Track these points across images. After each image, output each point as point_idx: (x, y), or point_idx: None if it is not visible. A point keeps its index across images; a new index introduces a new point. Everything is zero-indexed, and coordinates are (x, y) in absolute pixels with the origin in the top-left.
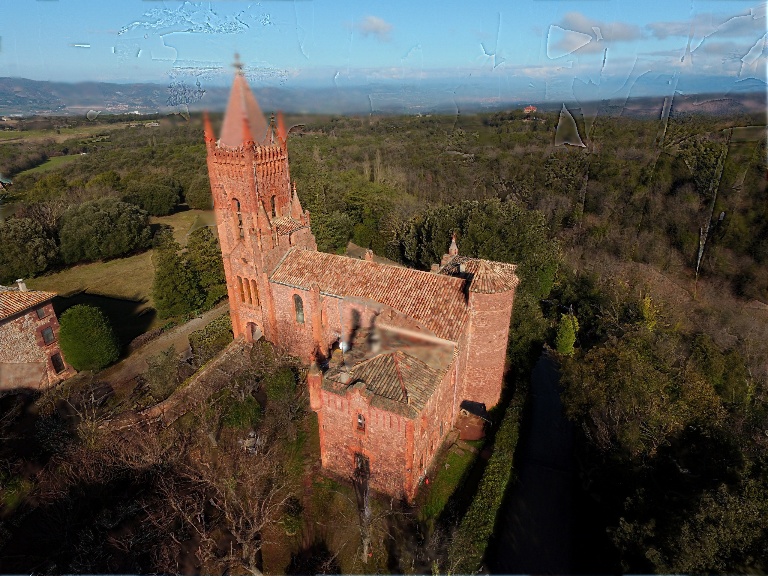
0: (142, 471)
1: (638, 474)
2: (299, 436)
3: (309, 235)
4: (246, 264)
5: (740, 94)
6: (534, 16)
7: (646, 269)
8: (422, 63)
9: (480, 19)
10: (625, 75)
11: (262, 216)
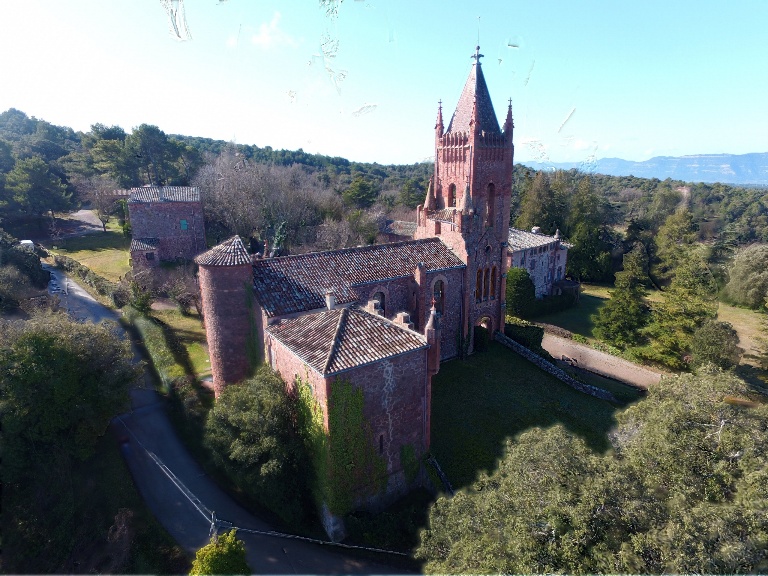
0: None
1: None
2: None
3: (459, 236)
4: None
5: None
6: None
7: None
8: None
9: None
10: None
11: None
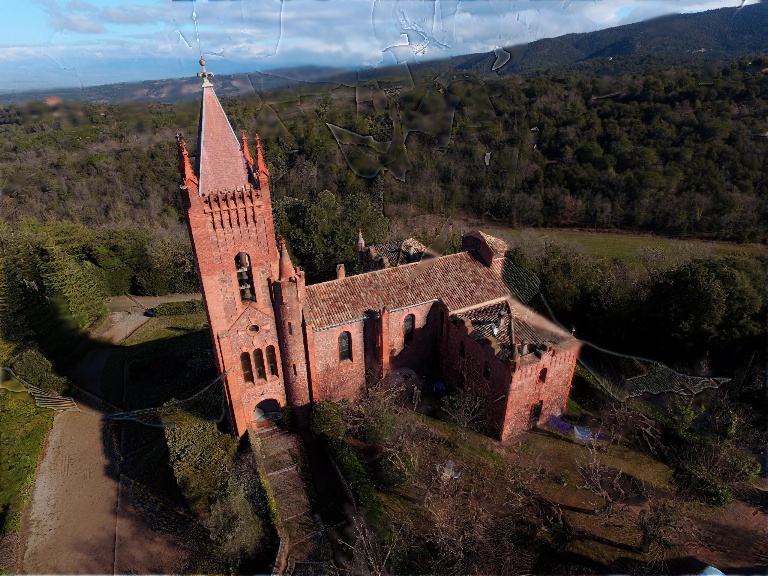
0: (523, 525)
1: (642, 308)
2: None
3: None
4: (257, 331)
5: (454, 86)
6: (213, 8)
7: (435, 217)
8: (74, 53)
9: (171, 7)
10: None
11: (289, 261)
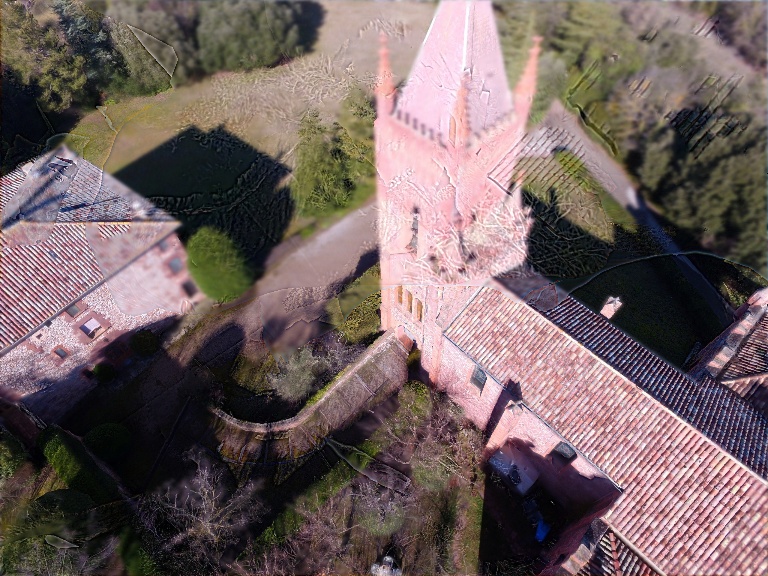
0: None
1: None
2: None
3: None
4: None
5: None
6: None
7: None
8: None
9: None
10: None
11: None
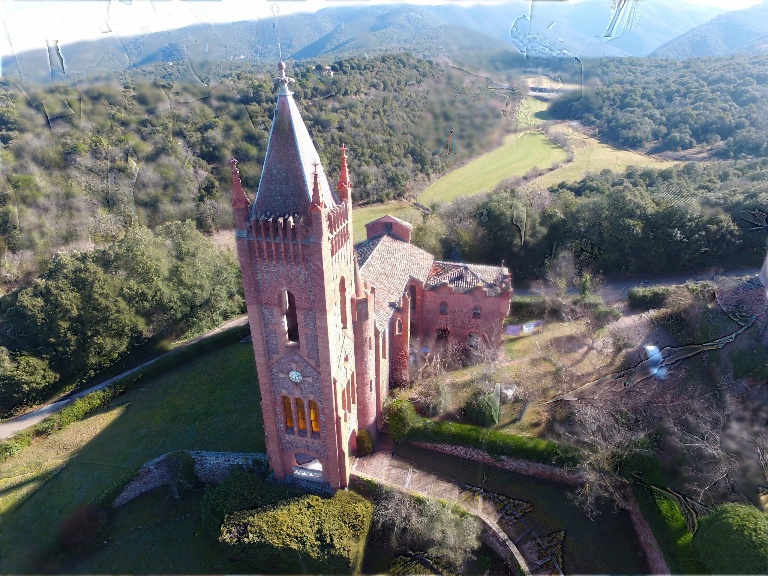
0: (609, 372)
1: None
2: (480, 376)
3: None
4: (347, 361)
5: (213, 92)
6: None
7: None
8: None
9: None
10: (45, 78)
11: None
